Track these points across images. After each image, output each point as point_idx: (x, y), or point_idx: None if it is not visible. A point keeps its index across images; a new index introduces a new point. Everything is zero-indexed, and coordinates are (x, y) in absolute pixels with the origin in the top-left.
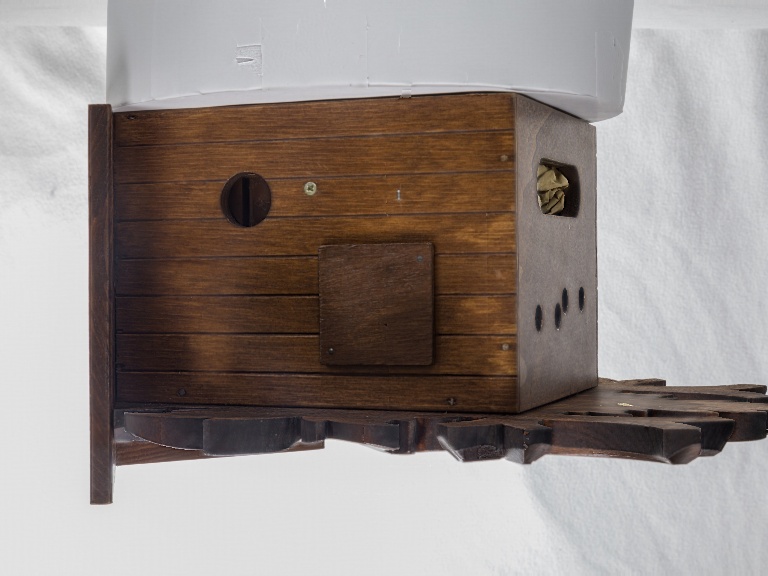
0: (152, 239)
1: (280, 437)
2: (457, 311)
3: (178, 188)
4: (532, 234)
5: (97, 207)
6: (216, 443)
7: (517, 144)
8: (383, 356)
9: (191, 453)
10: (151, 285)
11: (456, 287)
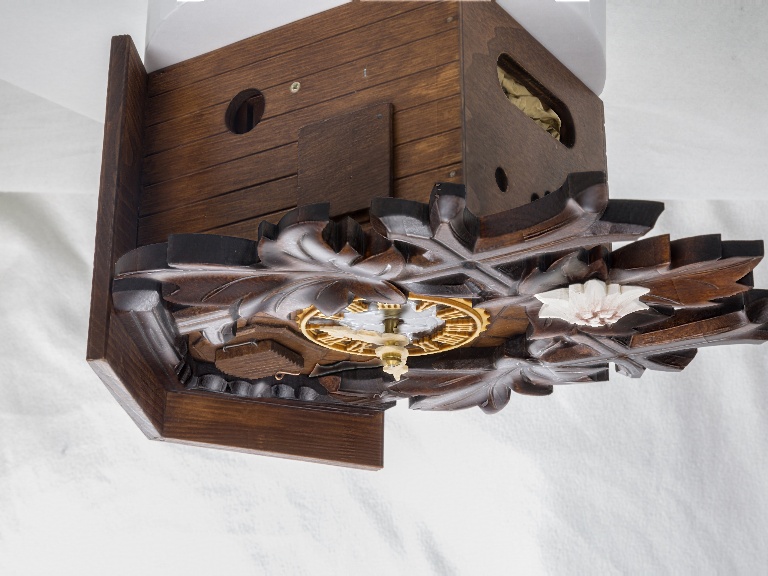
0: (170, 163)
1: (240, 254)
2: (412, 155)
3: (193, 117)
4: (489, 100)
5: (112, 113)
6: (178, 253)
7: (462, 9)
8: (348, 205)
9: (240, 441)
10: (167, 201)
11: (411, 135)
